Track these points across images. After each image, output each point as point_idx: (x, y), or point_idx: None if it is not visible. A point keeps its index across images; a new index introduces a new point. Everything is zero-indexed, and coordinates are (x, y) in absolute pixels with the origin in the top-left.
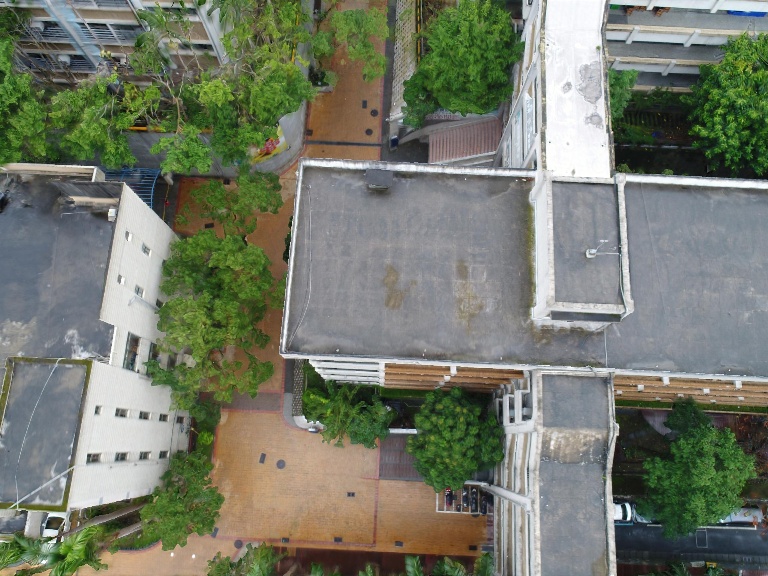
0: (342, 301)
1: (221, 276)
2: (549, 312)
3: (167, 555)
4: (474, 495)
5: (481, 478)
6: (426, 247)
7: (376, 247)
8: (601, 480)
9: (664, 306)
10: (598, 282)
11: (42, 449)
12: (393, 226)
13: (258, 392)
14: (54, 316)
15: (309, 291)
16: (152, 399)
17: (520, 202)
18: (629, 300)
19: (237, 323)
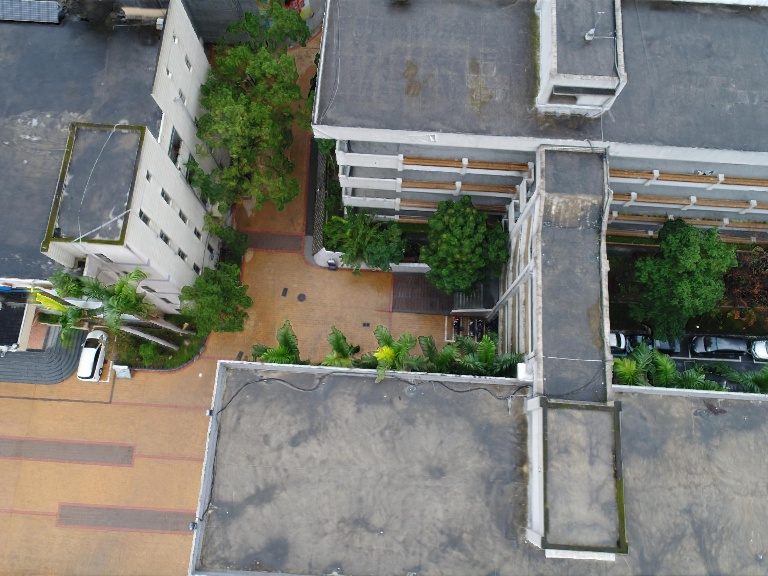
0: (367, 89)
1: (255, 87)
2: (552, 88)
3: (196, 375)
4: (480, 324)
5: (487, 307)
6: (442, 47)
7: (397, 46)
8: (597, 242)
9: (655, 98)
10: (595, 60)
11: (101, 197)
12: (413, 30)
13: (281, 234)
14: (107, 108)
15: (337, 81)
16: (189, 207)
17: (527, 12)
18: (623, 73)
19: (270, 124)
